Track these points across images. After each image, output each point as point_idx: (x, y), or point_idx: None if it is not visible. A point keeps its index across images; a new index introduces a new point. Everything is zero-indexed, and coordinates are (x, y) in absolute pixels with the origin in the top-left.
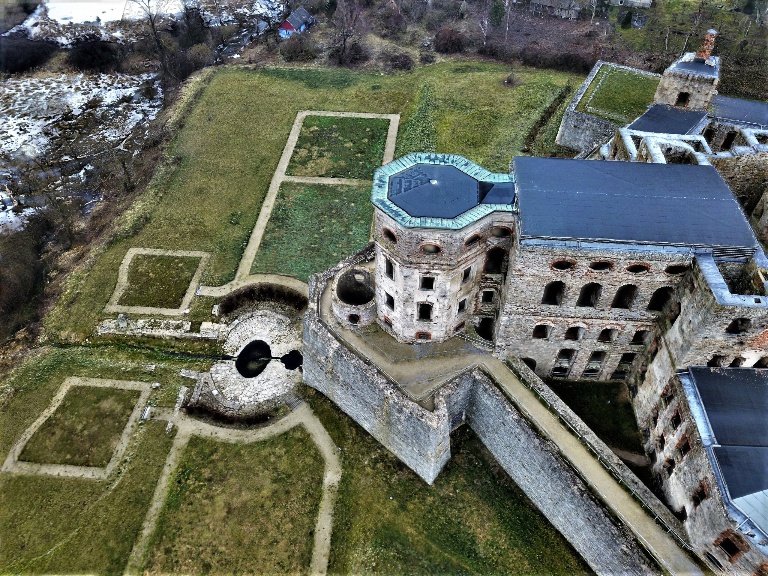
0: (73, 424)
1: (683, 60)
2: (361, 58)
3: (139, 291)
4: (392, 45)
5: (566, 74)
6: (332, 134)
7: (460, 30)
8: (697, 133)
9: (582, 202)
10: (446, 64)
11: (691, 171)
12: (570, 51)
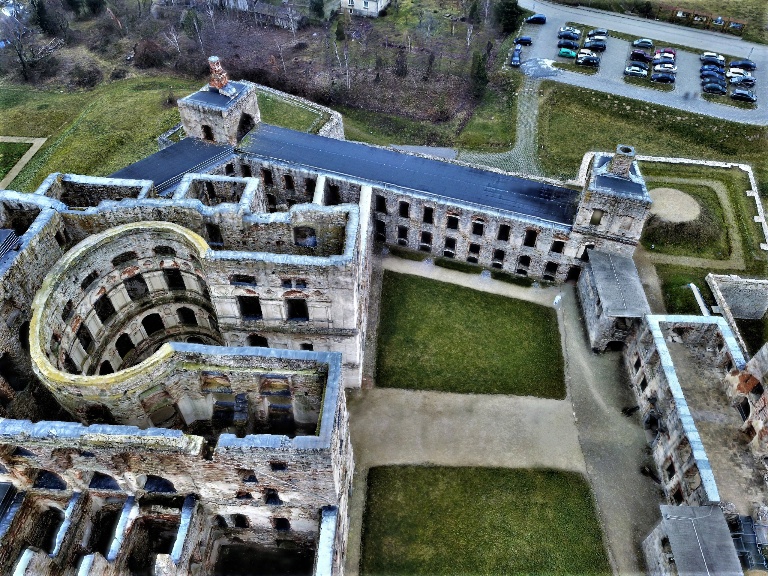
0: None
1: (201, 89)
2: (49, 74)
3: None
4: (95, 58)
5: None
6: None
7: None
8: (209, 171)
9: None
10: (135, 80)
11: None
12: (265, 65)
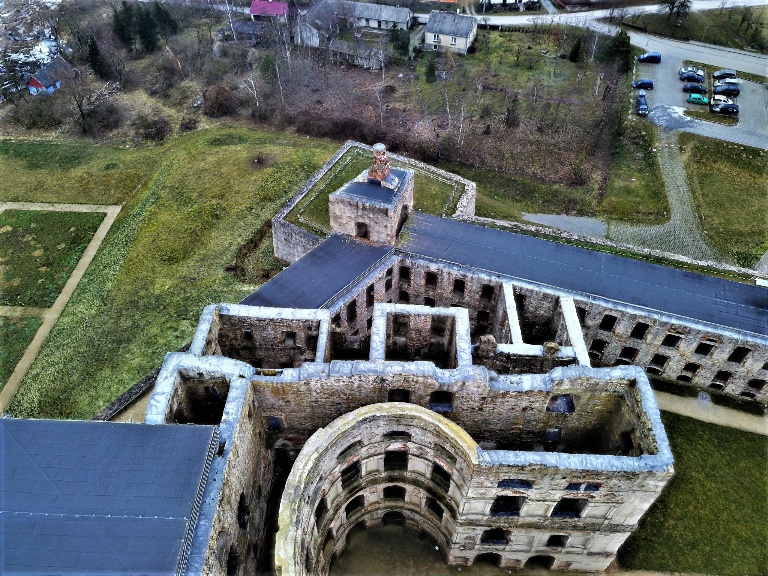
0: None
1: (356, 180)
2: (110, 125)
3: None
4: (157, 105)
5: (342, 145)
6: (24, 237)
7: (240, 85)
8: (371, 280)
9: None
10: (208, 132)
11: (169, 443)
12: (354, 114)
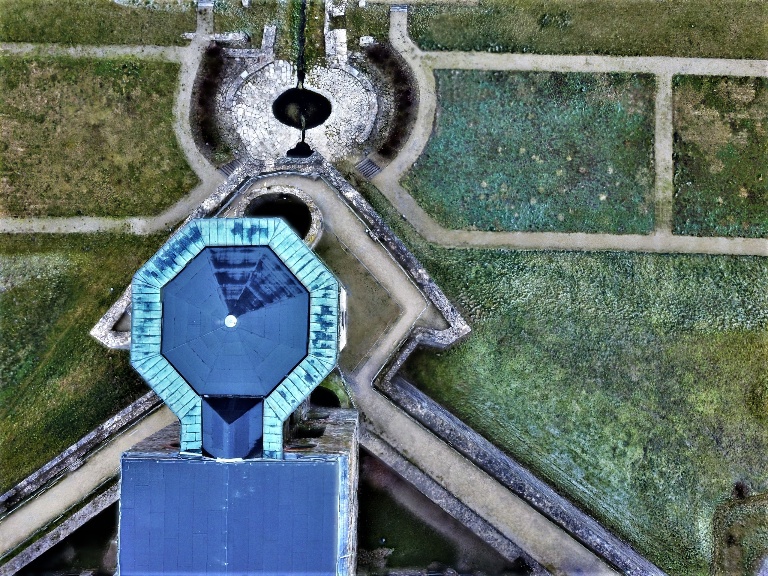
0: None
1: None
2: None
3: None
4: None
5: None
6: None
7: None
8: None
9: (201, 568)
10: None
11: None
12: None
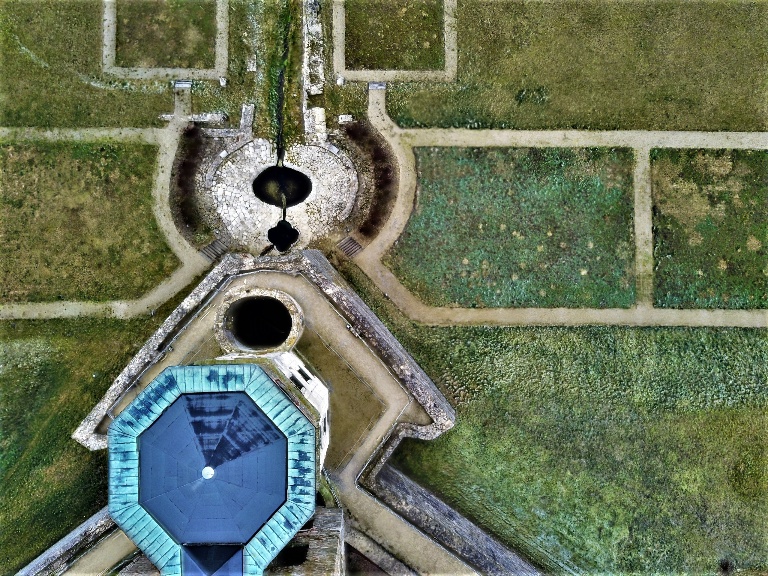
0: (164, 8)
1: None
2: None
3: (372, 6)
4: None
5: None
6: None
7: None
8: None
9: None
10: None
11: None
12: None
